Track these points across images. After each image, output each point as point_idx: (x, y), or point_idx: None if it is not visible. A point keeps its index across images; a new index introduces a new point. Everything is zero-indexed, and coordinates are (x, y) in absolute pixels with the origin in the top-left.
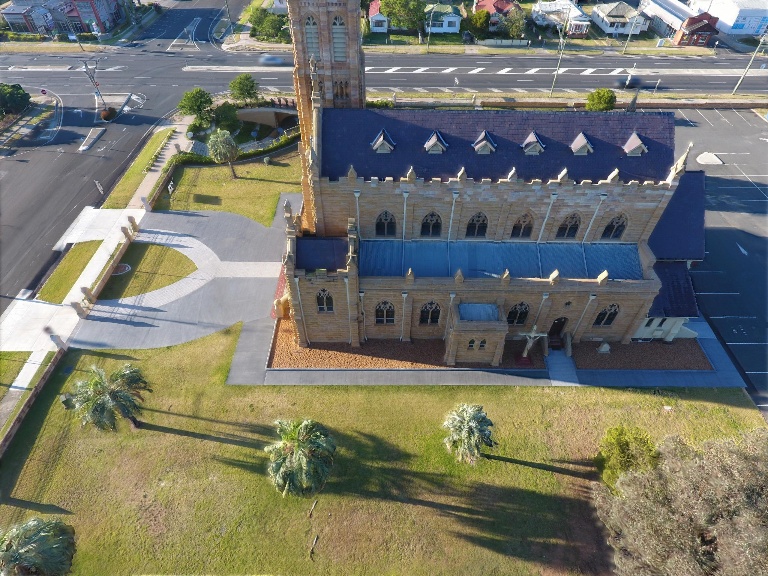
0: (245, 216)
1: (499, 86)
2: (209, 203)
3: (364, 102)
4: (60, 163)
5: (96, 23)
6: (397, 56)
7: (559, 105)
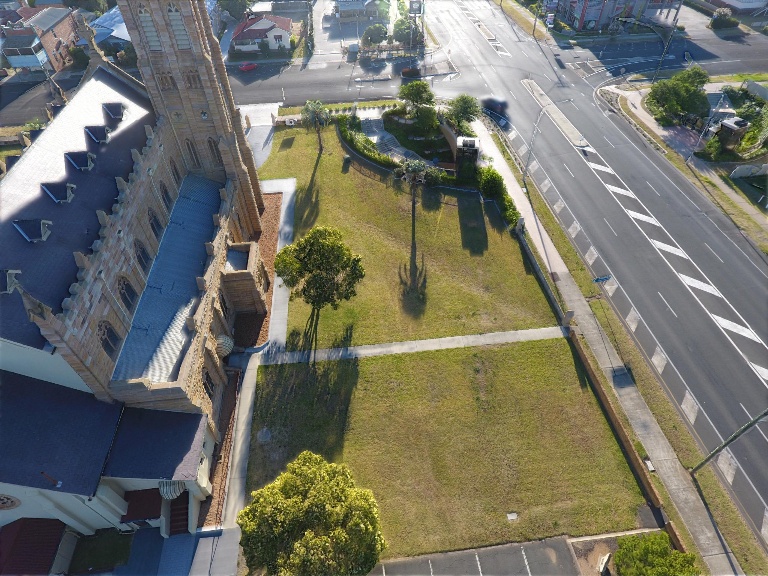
0: (260, 166)
1: (683, 366)
2: (281, 146)
3: (211, 114)
4: (336, 78)
5: (579, 19)
6: (711, 218)
7: (648, 485)
